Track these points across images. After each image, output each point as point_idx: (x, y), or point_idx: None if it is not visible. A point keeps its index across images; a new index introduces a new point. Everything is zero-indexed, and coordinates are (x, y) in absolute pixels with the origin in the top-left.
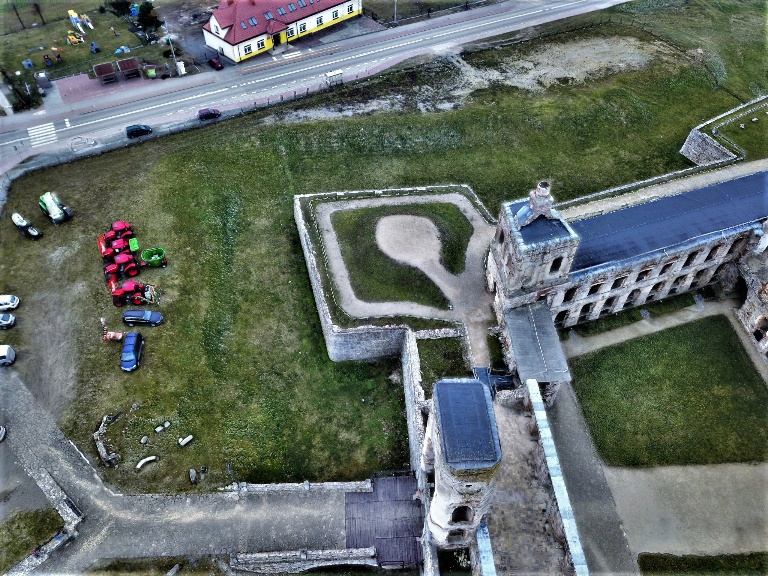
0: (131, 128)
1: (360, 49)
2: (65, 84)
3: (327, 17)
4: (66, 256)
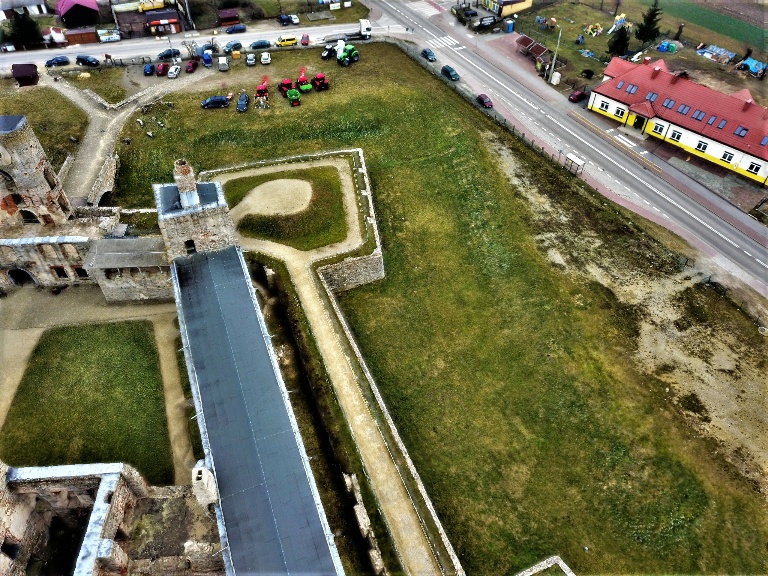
0: (446, 67)
1: (673, 190)
2: (513, 37)
3: (715, 150)
4: (306, 71)
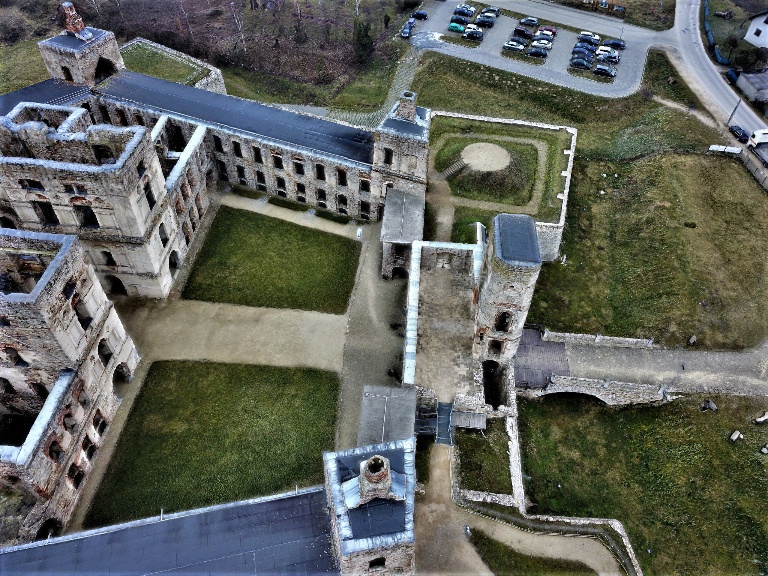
0: None
1: None
2: None
3: None
4: None
